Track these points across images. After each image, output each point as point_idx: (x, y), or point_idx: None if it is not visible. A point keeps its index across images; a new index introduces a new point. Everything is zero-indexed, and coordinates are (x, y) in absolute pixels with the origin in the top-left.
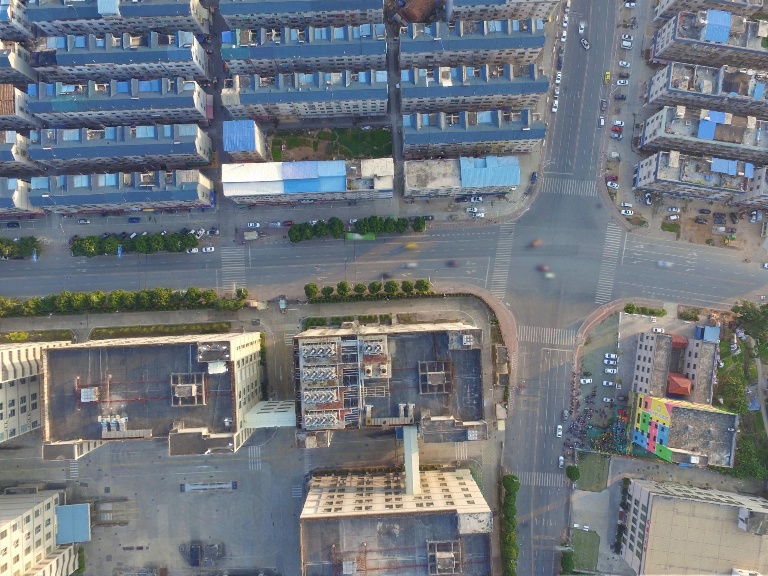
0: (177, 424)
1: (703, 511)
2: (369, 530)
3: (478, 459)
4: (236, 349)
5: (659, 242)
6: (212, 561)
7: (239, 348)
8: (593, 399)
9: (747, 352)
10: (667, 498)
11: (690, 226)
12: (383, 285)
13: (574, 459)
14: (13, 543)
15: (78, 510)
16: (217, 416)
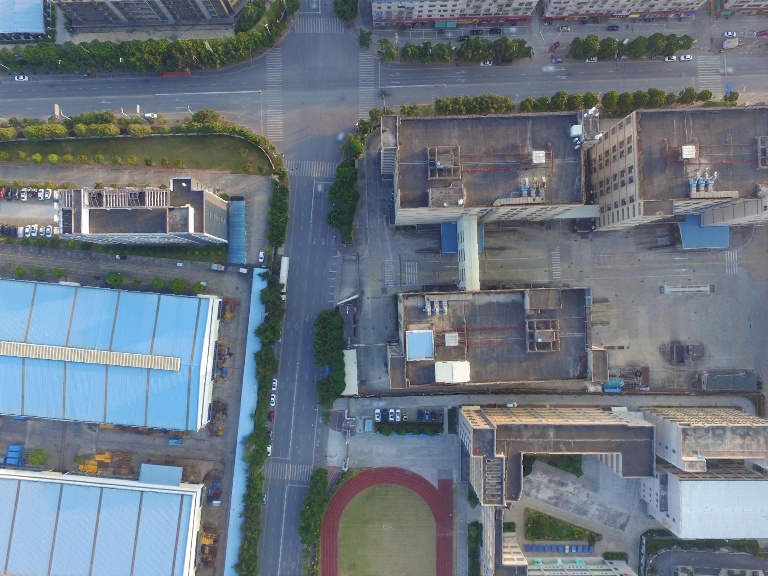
0: (762, 186)
1: None
2: None
3: None
4: None
5: None
6: (691, 361)
7: None
8: None
9: None
10: None
11: None
12: None
13: None
14: None
15: None
16: None
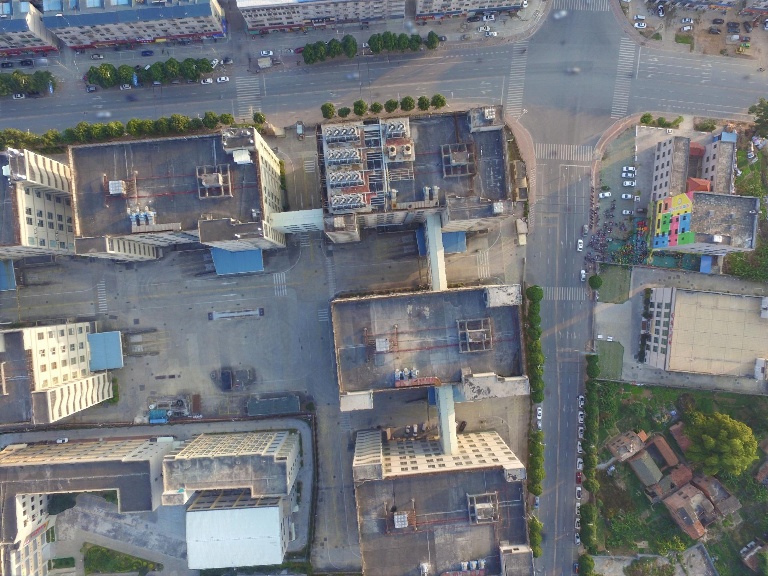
0: None
1: (726, 303)
2: (400, 313)
3: (501, 276)
4: (259, 142)
5: (673, 55)
6: (243, 386)
7: (262, 145)
8: (612, 212)
9: (764, 160)
10: (690, 292)
11: (704, 37)
12: (399, 102)
13: (596, 272)
14: (50, 349)
15: (109, 337)
16: (244, 208)
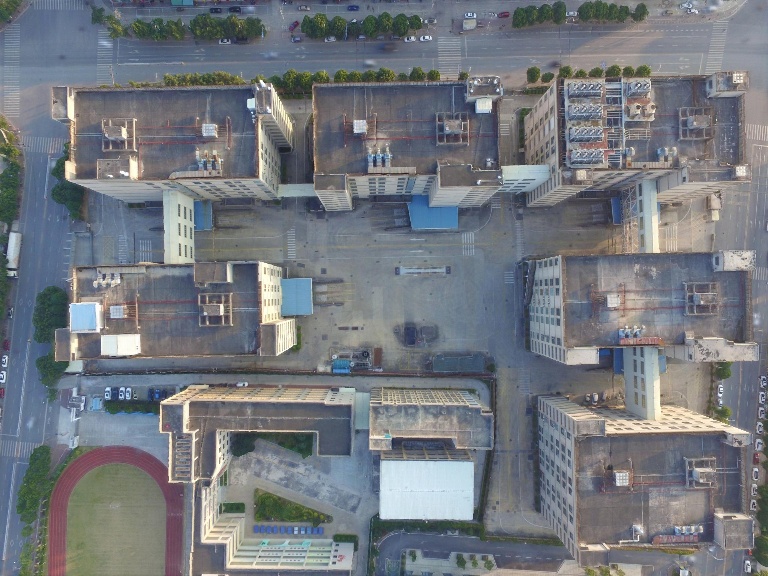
0: None
1: None
2: (627, 272)
3: (688, 251)
4: None
5: None
6: (425, 343)
7: None
8: None
9: None
10: None
11: None
12: (605, 71)
13: None
14: (267, 285)
15: (301, 284)
16: (478, 157)
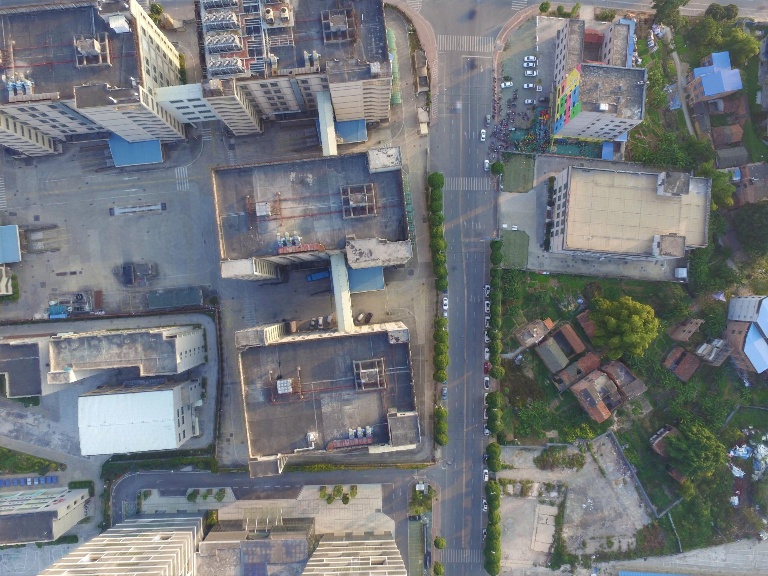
0: None
1: (622, 181)
2: (282, 180)
3: (404, 168)
4: (139, 13)
5: None
6: (146, 282)
7: (144, 18)
8: (515, 102)
9: (665, 49)
10: (586, 171)
11: None
12: None
13: (499, 161)
14: None
15: (6, 231)
16: (124, 78)
